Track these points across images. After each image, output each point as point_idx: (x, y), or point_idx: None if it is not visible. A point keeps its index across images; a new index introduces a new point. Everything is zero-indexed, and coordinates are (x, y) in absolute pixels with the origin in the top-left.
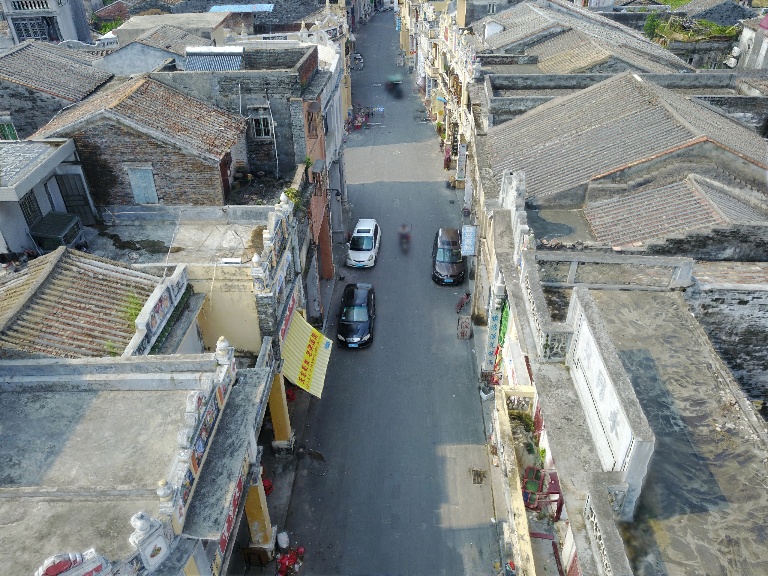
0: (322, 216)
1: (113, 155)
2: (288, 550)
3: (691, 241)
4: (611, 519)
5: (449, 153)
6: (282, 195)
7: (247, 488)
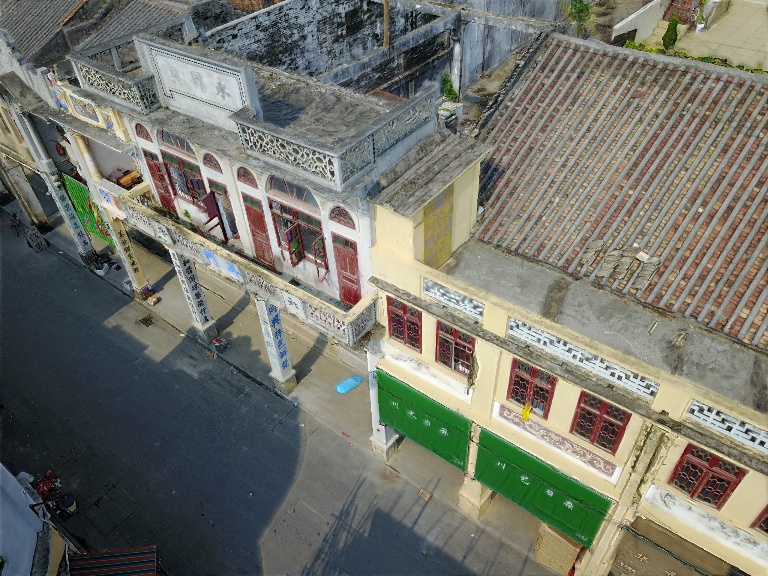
0: None
1: None
2: (37, 483)
3: (173, 32)
4: (259, 122)
5: None
6: None
7: None
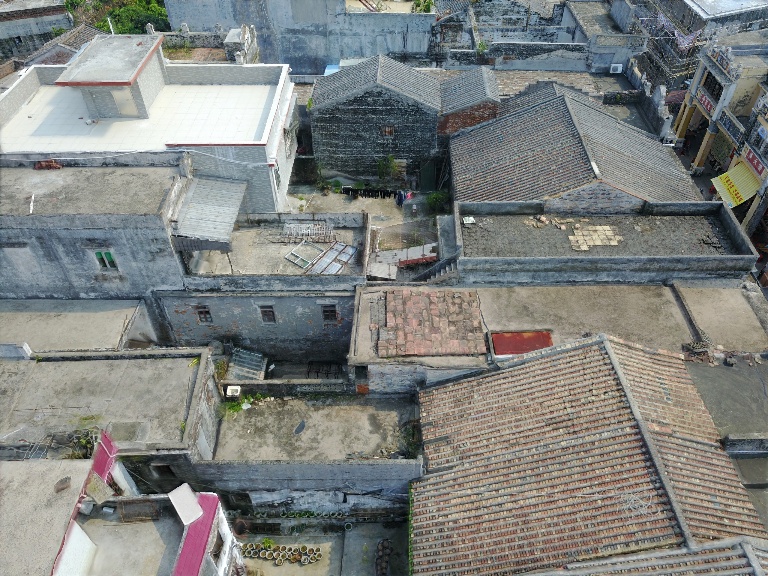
0: None
1: None
2: None
3: None
4: None
5: None
6: None
7: (708, 114)
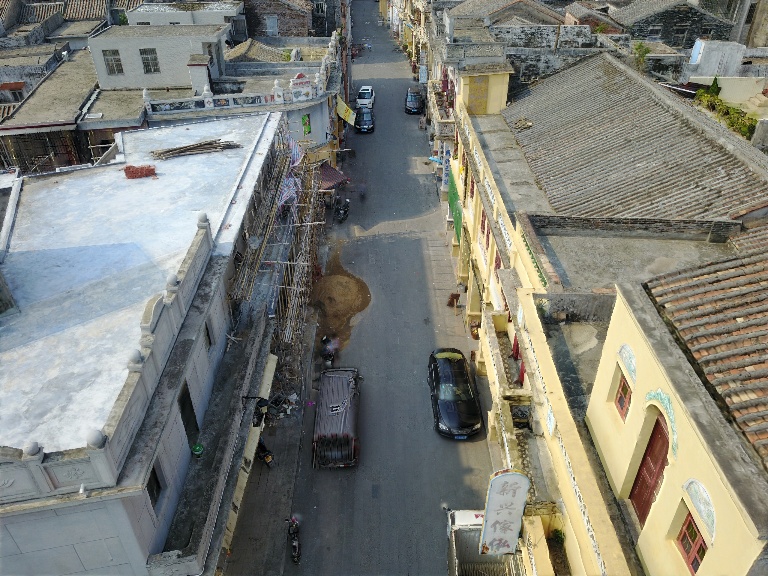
0: (345, 67)
1: (260, 10)
2: None
3: None
4: None
5: (415, 63)
6: (335, 31)
7: None
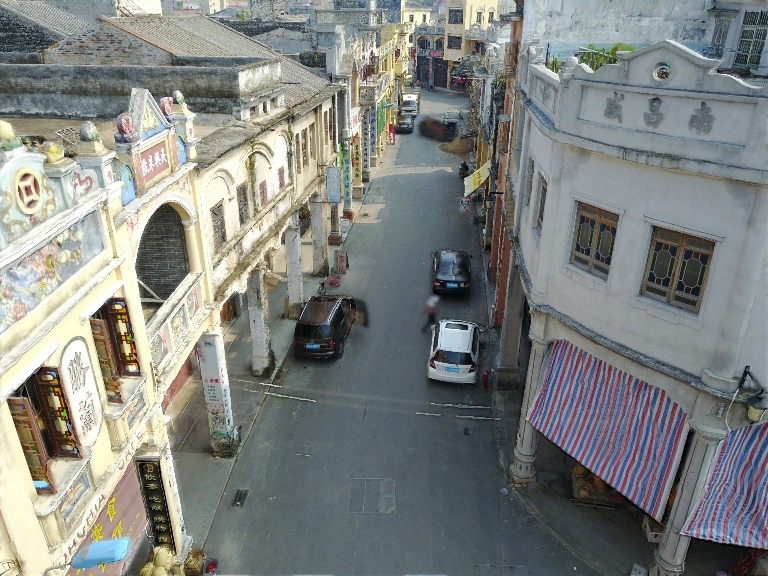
0: None
1: None
2: None
3: None
4: None
5: None
6: None
7: None
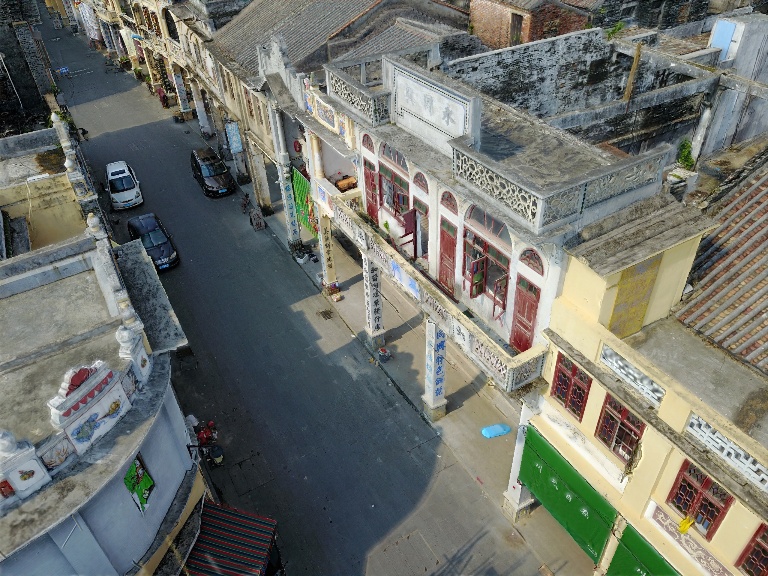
0: None
1: None
2: (199, 428)
3: (420, 58)
4: (475, 151)
5: (163, 91)
6: (53, 115)
7: None
